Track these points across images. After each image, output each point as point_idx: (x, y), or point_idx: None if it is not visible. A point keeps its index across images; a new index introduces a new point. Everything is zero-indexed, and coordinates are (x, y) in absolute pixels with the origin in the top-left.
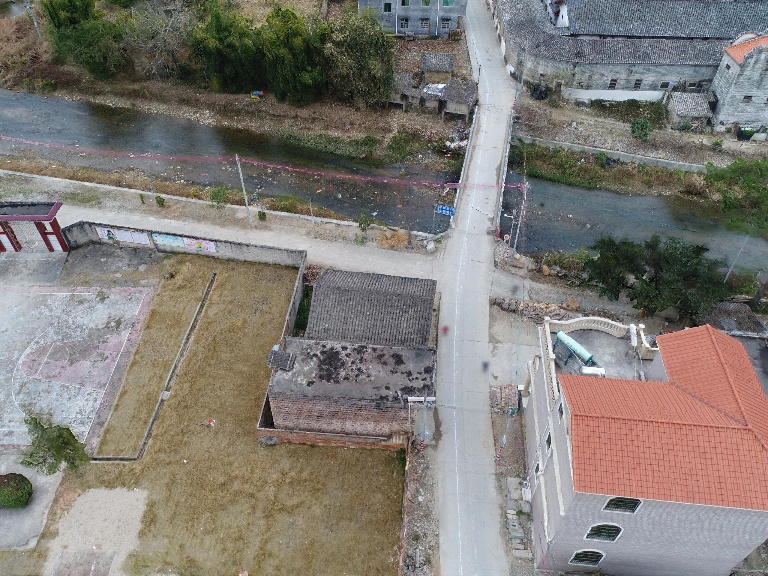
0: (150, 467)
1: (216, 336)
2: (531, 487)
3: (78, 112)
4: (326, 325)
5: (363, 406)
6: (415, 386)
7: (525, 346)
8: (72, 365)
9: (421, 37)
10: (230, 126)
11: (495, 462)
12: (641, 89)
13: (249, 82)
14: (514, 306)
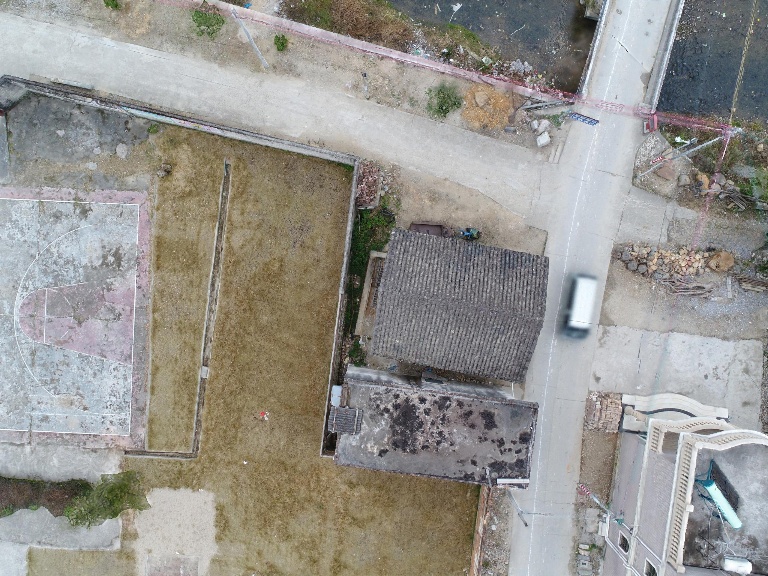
0: (209, 468)
1: (249, 287)
2: (610, 526)
3: None
4: (396, 341)
5: None
6: (507, 461)
7: (644, 332)
8: (81, 325)
9: None
10: None
11: (577, 490)
12: None
13: None
14: (645, 268)
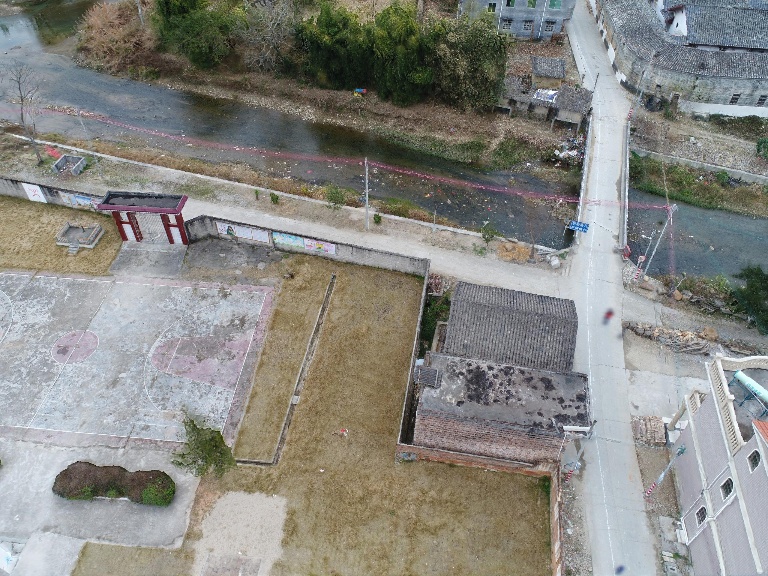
0: (287, 474)
1: (341, 342)
2: (687, 529)
3: (182, 101)
4: (465, 341)
5: (515, 431)
6: (569, 414)
7: (664, 375)
8: (201, 362)
9: (522, 39)
10: (332, 123)
11: (644, 498)
12: (765, 105)
13: (353, 79)
14: (650, 332)
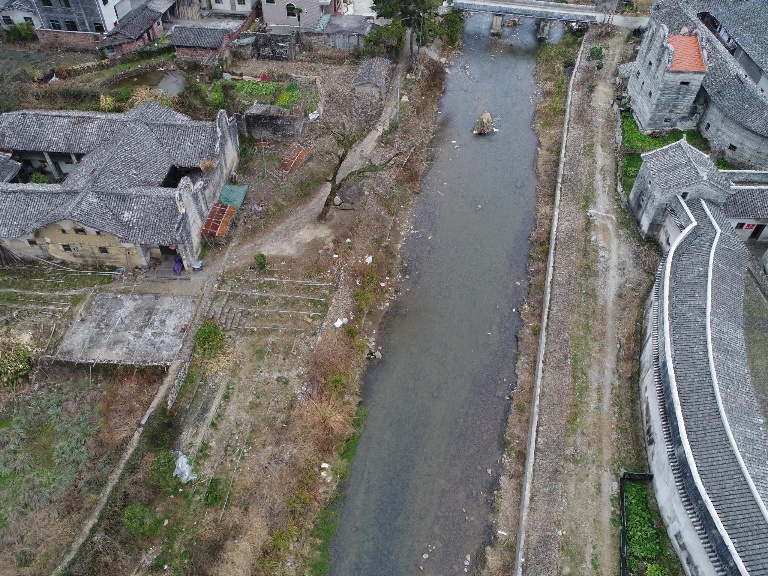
0: None
1: None
2: None
3: None
4: None
5: None
6: None
7: None
8: None
9: None
10: None
11: None
12: None
13: None
14: None
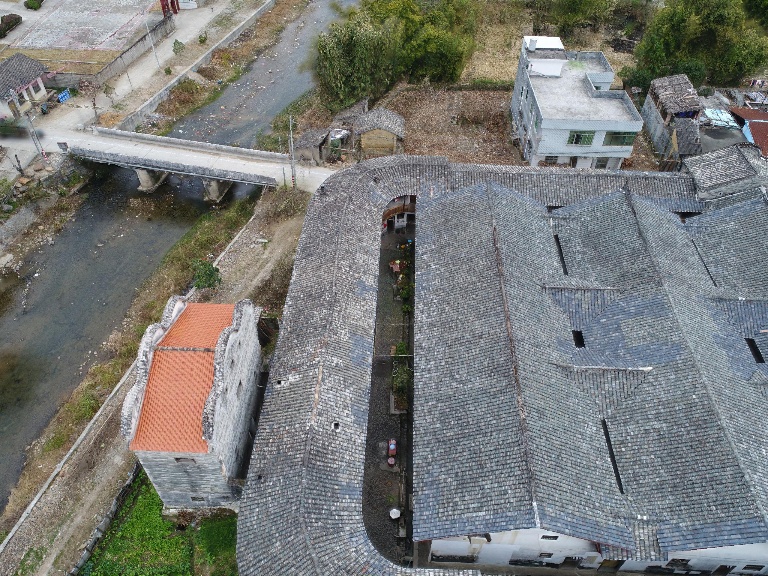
0: None
1: None
2: None
3: None
4: None
5: None
6: None
7: None
8: None
9: None
10: None
11: None
12: None
13: None
14: None
